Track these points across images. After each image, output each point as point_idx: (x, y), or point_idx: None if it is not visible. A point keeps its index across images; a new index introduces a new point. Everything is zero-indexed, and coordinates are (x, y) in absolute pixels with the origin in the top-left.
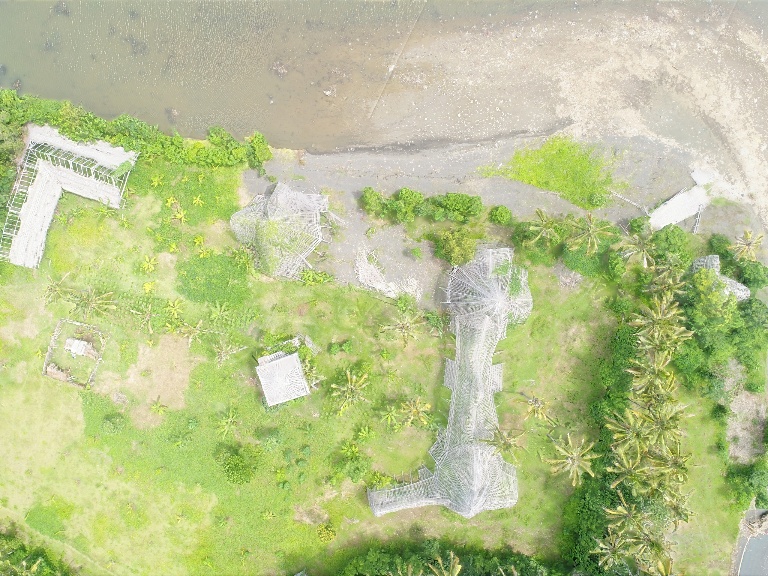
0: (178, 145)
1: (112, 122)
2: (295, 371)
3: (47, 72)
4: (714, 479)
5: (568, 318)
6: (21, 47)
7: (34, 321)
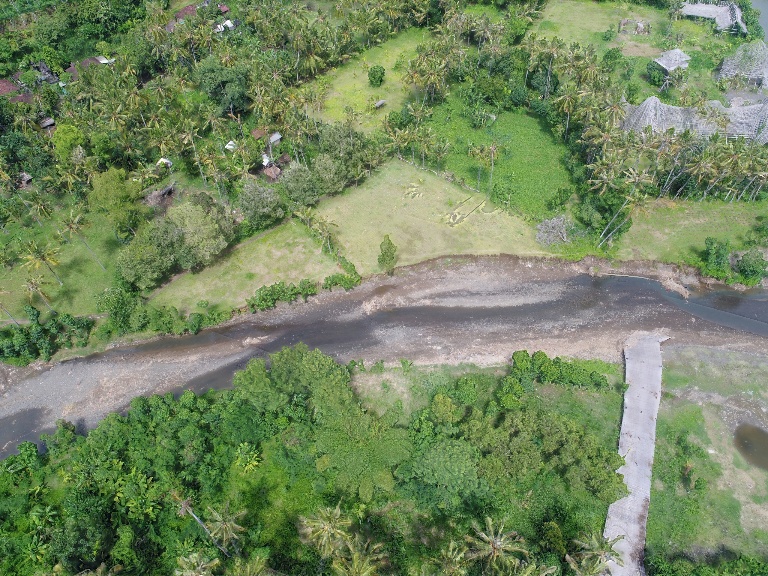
0: None
1: None
2: (683, 58)
3: (761, 22)
4: (700, 246)
5: None
6: (767, 16)
7: (643, 19)
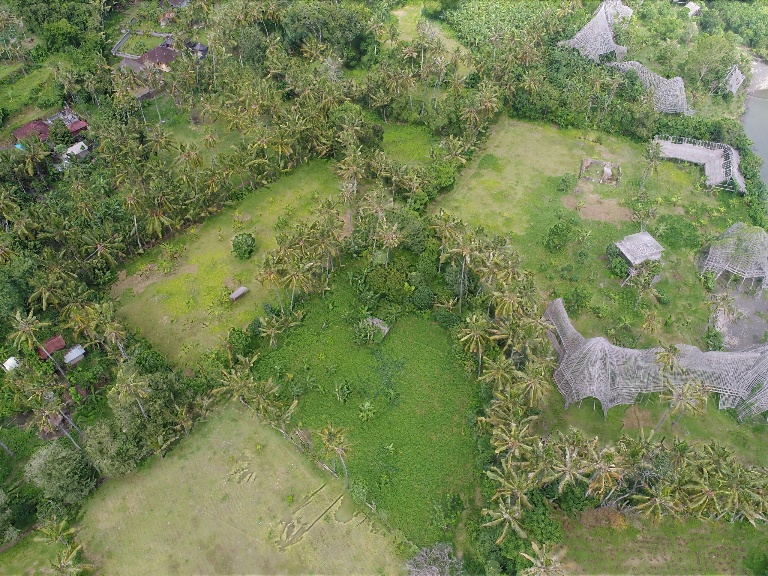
0: (763, 211)
1: (761, 181)
2: (654, 249)
3: (765, 166)
4: None
5: (761, 463)
6: None
7: (612, 157)
